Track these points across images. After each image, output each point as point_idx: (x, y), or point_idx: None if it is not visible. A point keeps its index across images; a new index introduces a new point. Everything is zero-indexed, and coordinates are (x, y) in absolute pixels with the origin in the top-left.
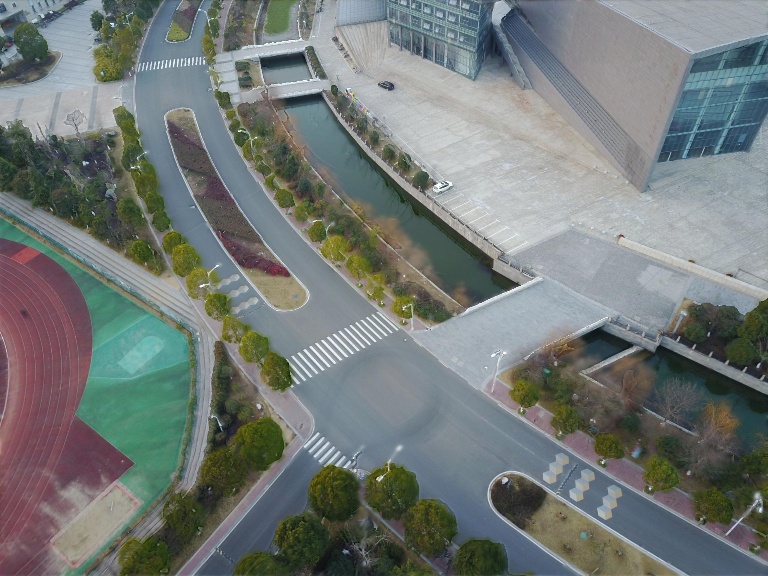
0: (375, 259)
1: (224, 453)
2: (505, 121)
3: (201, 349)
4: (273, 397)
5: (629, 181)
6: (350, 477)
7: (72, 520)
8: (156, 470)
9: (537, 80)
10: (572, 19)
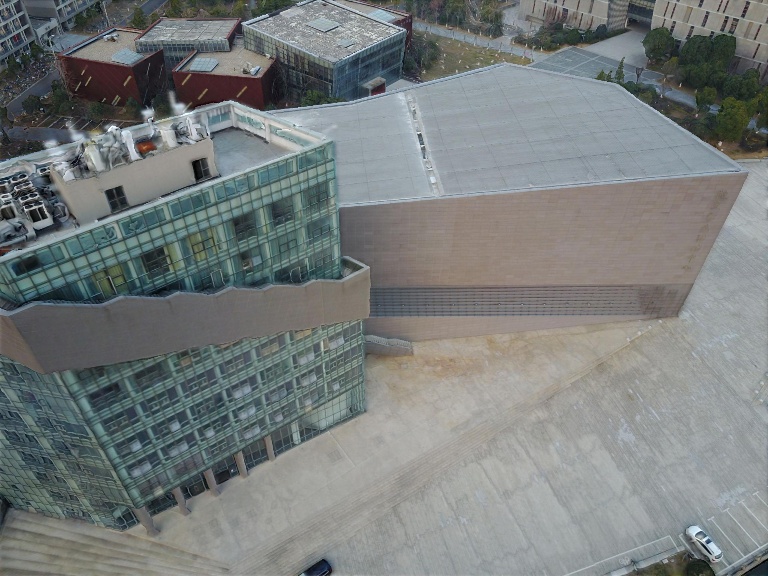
0: None
1: None
2: (505, 403)
3: None
4: None
5: (657, 319)
6: None
7: None
8: None
9: (421, 329)
10: (444, 233)
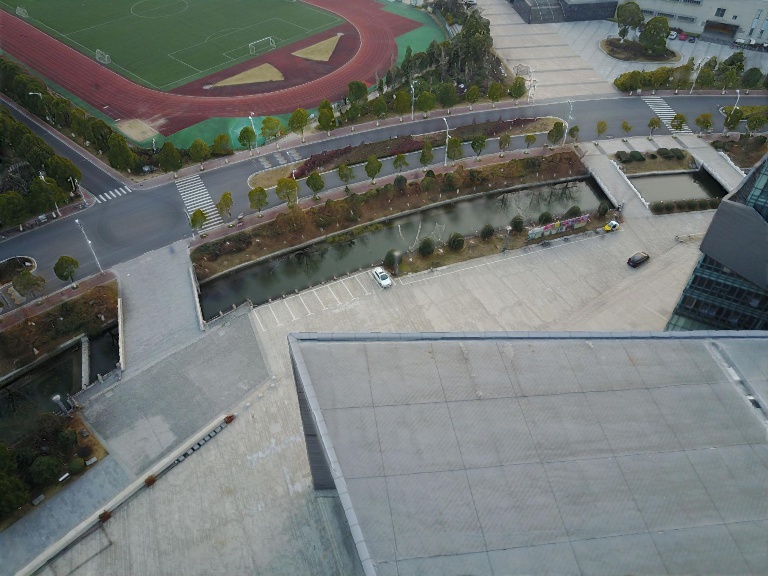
0: (277, 217)
1: (101, 126)
2: None
3: (238, 151)
4: (172, 174)
5: None
6: (54, 169)
7: (144, 123)
8: (156, 144)
9: None
10: None
